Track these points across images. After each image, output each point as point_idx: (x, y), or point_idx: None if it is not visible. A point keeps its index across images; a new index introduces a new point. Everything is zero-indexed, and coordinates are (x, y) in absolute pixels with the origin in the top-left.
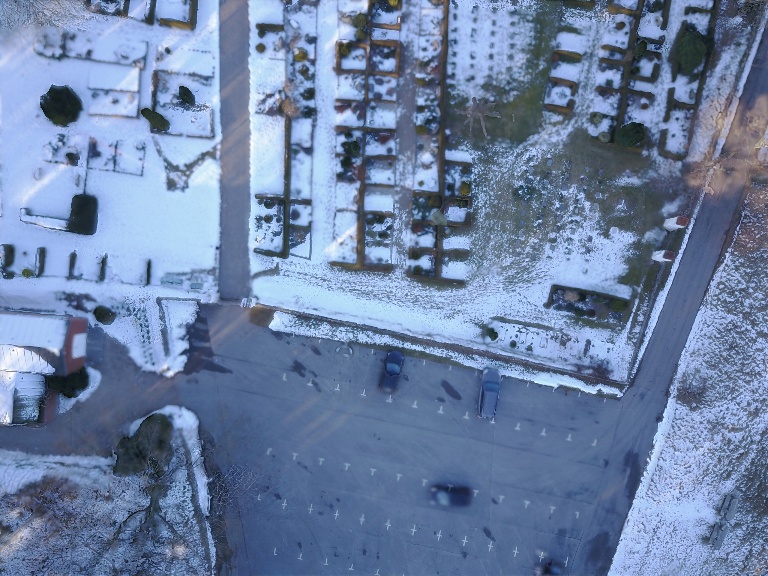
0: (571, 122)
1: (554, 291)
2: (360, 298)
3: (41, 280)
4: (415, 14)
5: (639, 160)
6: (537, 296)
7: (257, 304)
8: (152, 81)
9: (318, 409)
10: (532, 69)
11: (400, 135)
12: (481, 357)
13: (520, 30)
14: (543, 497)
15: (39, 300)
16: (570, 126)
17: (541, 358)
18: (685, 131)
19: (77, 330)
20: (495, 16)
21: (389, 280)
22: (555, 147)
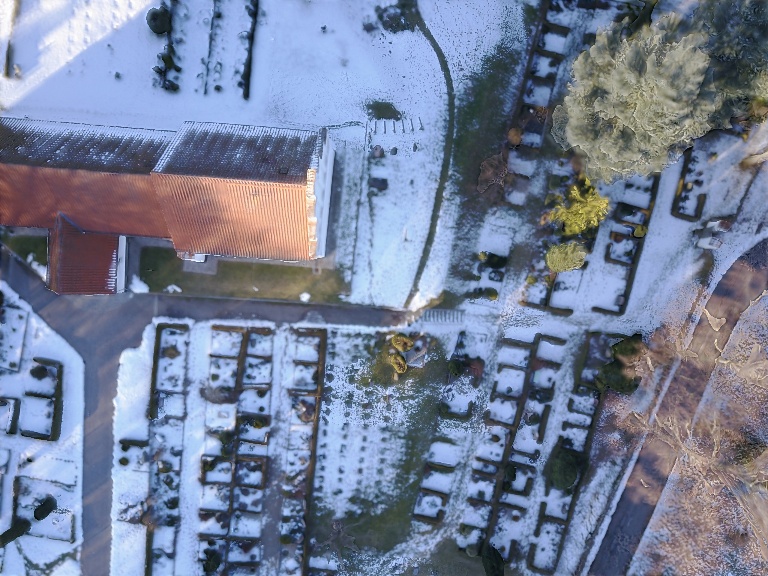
0: (440, 532)
1: None
2: None
3: None
4: (284, 429)
5: (507, 571)
6: None
7: None
8: (13, 487)
9: None
10: (402, 483)
11: (265, 542)
12: None
13: (391, 446)
14: None
15: None
16: (439, 536)
17: None
18: (555, 546)
19: None
20: (366, 432)
21: None
22: (422, 556)
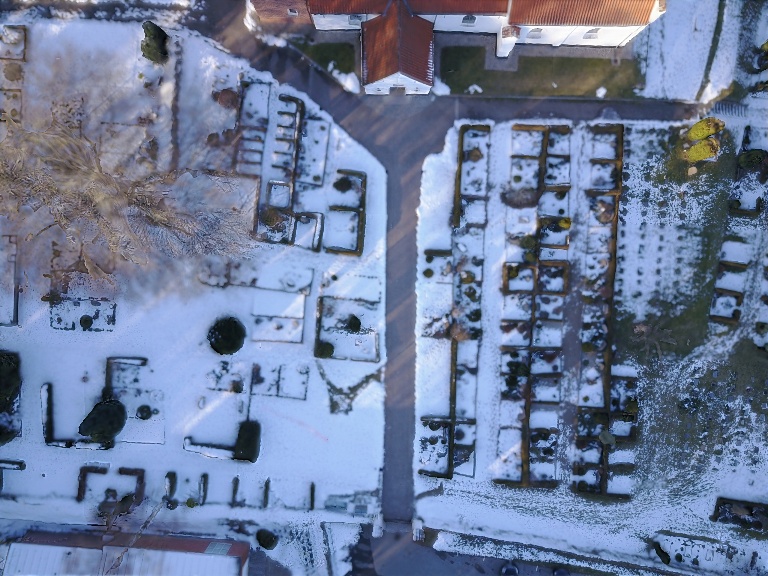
0: (736, 332)
1: (721, 504)
2: (524, 514)
3: (204, 508)
4: (583, 232)
5: None
6: (703, 509)
7: (423, 528)
8: (318, 308)
9: None
10: (699, 283)
11: (565, 352)
12: (646, 572)
13: (687, 244)
14: None
15: (200, 525)
16: (735, 336)
17: (708, 573)
18: None
19: (243, 560)
20: (662, 231)
21: (553, 496)
22: (721, 358)
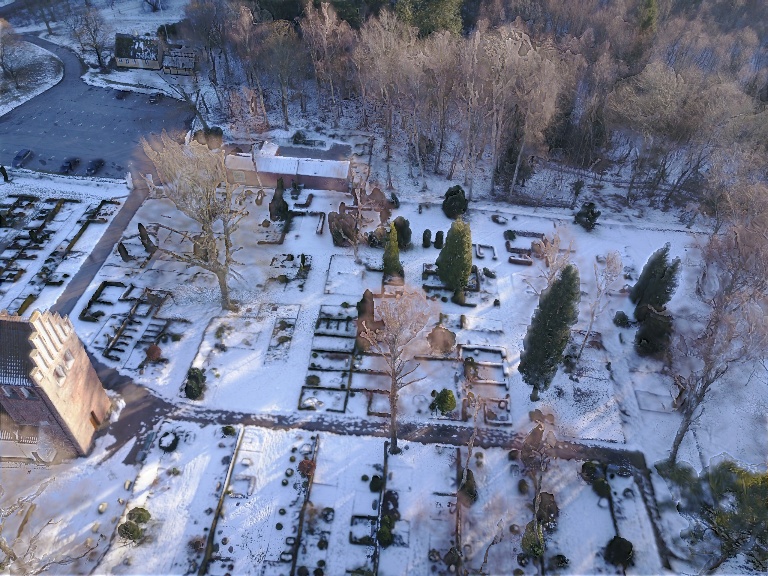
0: None
1: None
2: None
3: None
4: None
5: None
6: None
7: None
8: (145, 263)
9: (117, 157)
10: None
11: None
12: None
13: None
14: (20, 133)
15: None
16: None
17: None
18: None
19: None
20: None
21: None
22: None
